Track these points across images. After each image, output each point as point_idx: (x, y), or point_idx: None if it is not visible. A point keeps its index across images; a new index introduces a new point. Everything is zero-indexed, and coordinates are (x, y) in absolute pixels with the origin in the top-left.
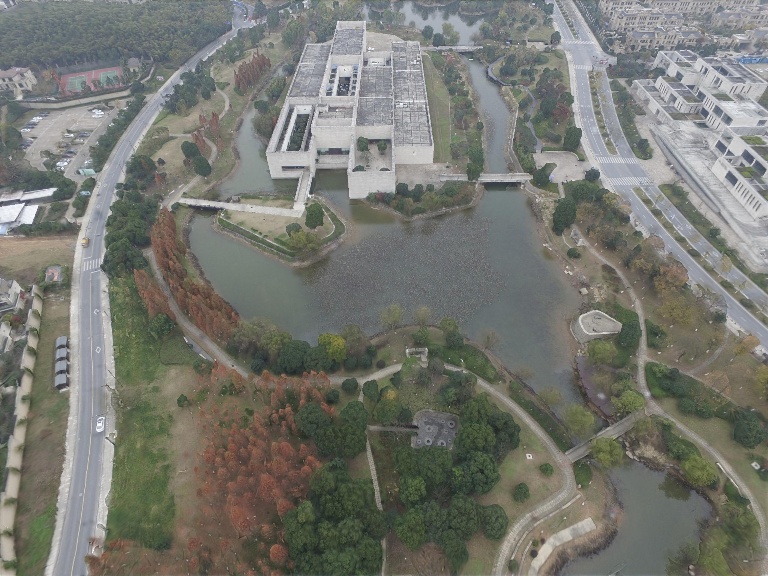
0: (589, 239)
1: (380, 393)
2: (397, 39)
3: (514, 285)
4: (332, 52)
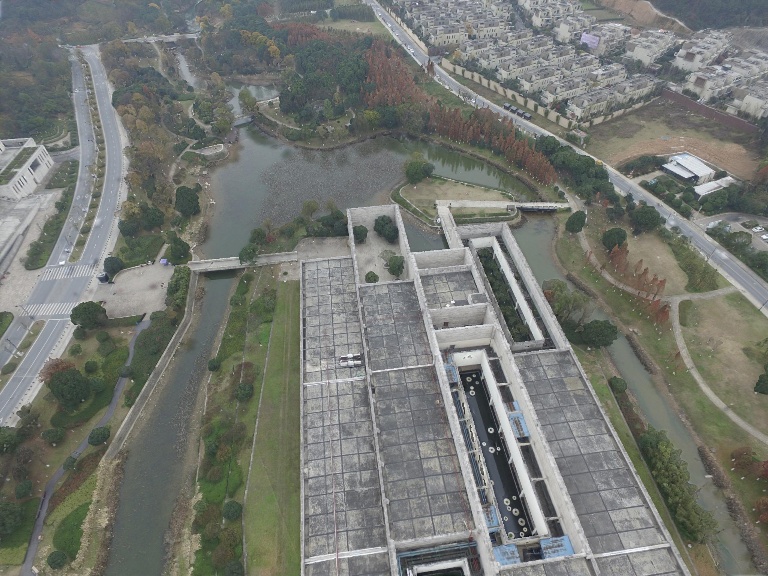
0: (174, 202)
1: (343, 106)
2: None
3: (254, 175)
4: None
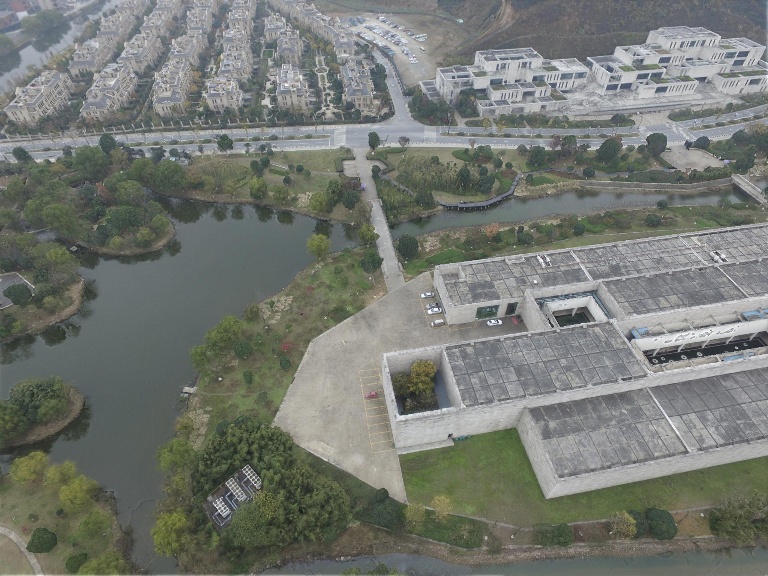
0: None
1: None
2: (345, 329)
3: None
4: (623, 379)
